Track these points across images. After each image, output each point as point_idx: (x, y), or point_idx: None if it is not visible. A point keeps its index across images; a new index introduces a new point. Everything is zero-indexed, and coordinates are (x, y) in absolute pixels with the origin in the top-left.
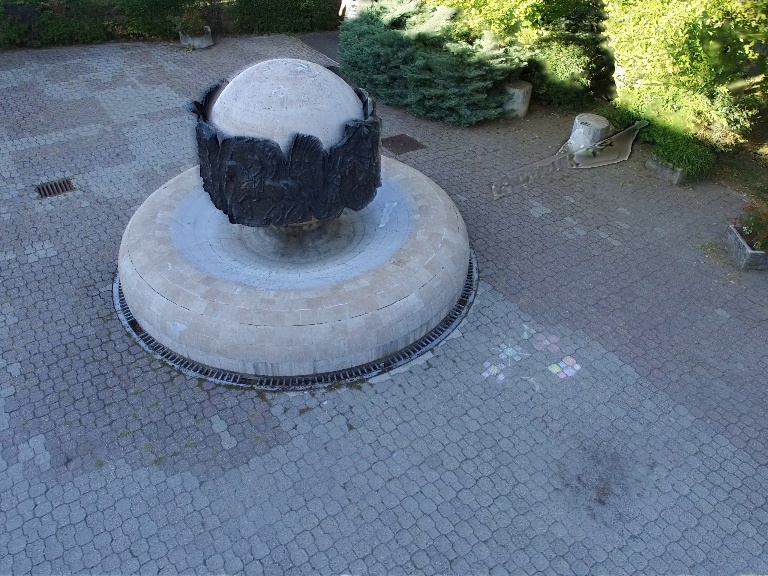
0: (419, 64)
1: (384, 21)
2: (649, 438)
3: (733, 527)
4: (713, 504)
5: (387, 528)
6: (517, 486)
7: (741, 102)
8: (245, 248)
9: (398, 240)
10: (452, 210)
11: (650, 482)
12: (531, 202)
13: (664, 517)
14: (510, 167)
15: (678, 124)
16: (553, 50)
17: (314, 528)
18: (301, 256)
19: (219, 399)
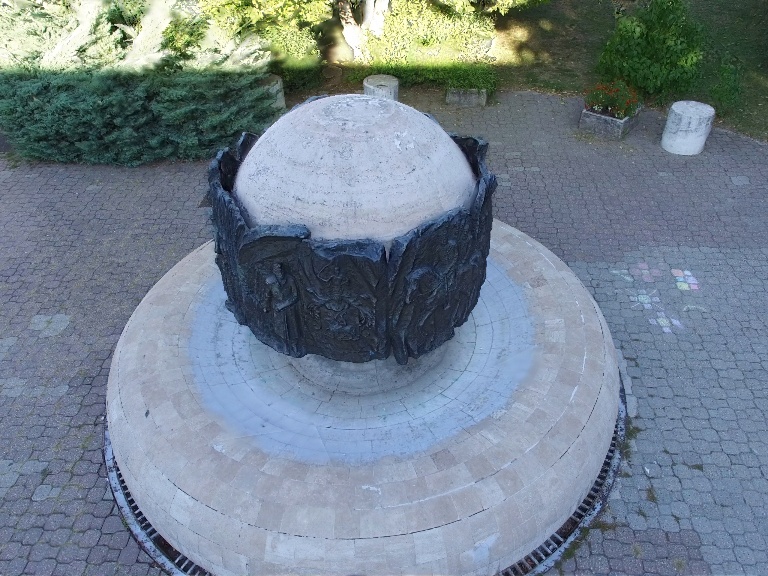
0: (180, 95)
1: (54, 67)
2: None
3: None
4: None
5: None
6: None
7: None
8: (358, 398)
9: None
10: None
11: None
12: None
13: None
14: None
15: (444, 54)
16: (271, 31)
17: None
18: (426, 355)
19: None
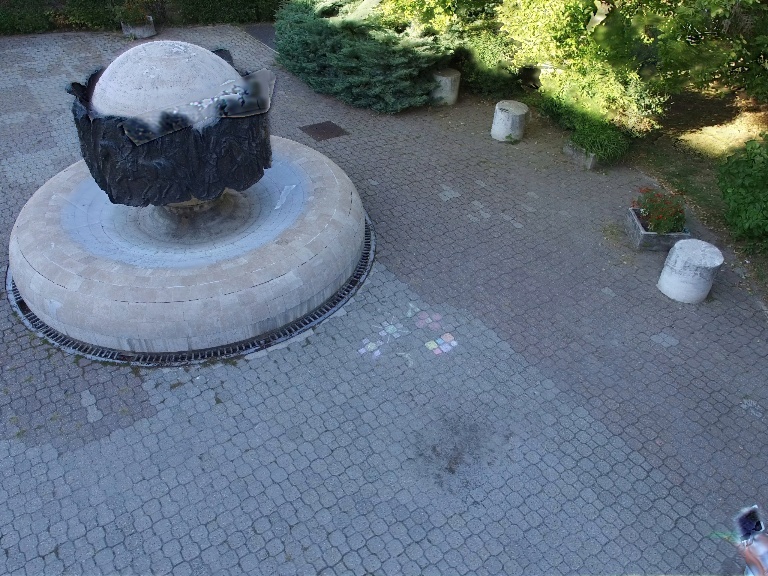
0: (344, 52)
1: None
2: (511, 410)
3: (575, 493)
4: (560, 472)
5: (235, 496)
6: (371, 456)
7: (651, 88)
8: (138, 229)
9: (288, 221)
10: (347, 192)
11: (503, 452)
12: (442, 186)
13: (510, 484)
14: (429, 153)
15: (595, 110)
16: (481, 38)
17: (163, 496)
18: (192, 237)
19: (93, 375)
